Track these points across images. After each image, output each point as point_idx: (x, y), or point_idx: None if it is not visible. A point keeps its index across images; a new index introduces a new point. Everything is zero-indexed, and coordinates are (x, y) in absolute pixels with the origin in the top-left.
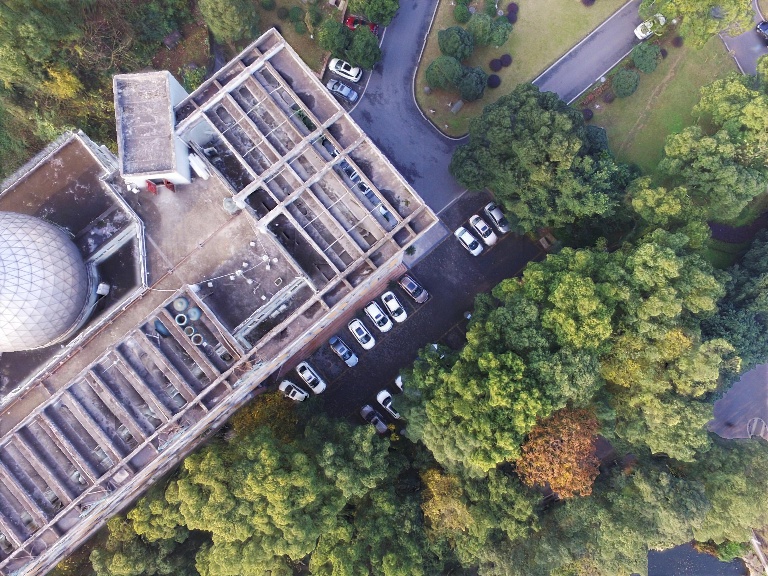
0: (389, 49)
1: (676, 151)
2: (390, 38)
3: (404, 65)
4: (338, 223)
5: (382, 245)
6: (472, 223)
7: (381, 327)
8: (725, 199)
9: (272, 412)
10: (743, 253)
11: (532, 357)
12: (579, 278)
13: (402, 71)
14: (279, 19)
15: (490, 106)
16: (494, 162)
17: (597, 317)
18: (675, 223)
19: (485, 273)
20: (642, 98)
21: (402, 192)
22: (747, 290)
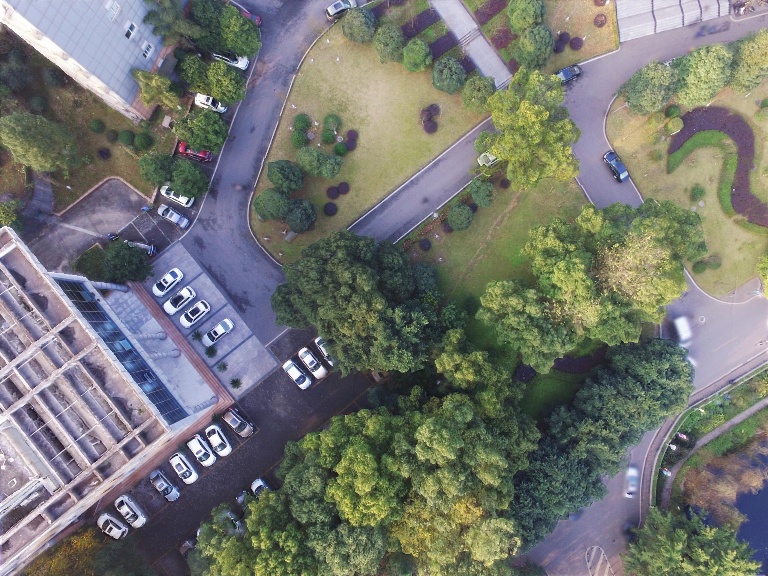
0: (225, 173)
1: (490, 304)
2: (226, 162)
3: (239, 190)
4: (65, 433)
5: (111, 455)
6: (300, 357)
7: (203, 462)
8: (531, 360)
9: (70, 562)
10: (578, 388)
11: (309, 534)
12: (360, 454)
13: (237, 196)
14: (108, 142)
15: (306, 251)
16: (306, 310)
17: (375, 496)
18: (478, 384)
19: (314, 406)
20: (483, 228)
21: (135, 400)
22: (571, 434)
